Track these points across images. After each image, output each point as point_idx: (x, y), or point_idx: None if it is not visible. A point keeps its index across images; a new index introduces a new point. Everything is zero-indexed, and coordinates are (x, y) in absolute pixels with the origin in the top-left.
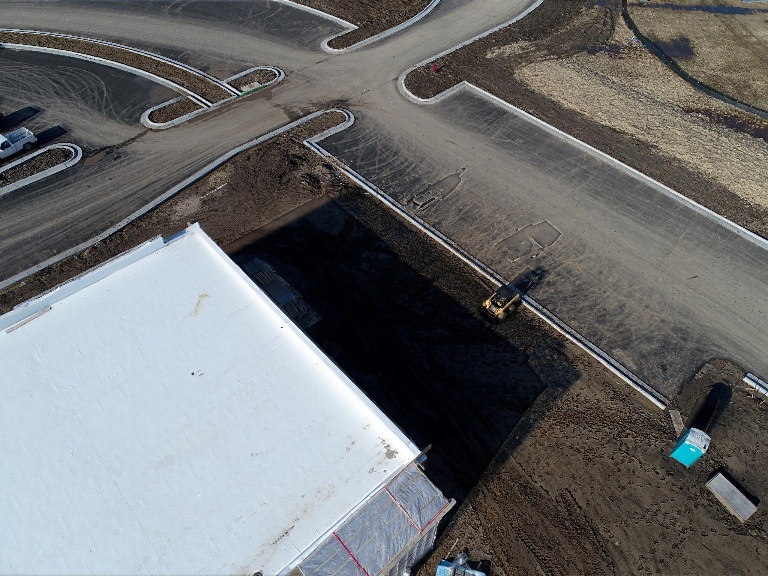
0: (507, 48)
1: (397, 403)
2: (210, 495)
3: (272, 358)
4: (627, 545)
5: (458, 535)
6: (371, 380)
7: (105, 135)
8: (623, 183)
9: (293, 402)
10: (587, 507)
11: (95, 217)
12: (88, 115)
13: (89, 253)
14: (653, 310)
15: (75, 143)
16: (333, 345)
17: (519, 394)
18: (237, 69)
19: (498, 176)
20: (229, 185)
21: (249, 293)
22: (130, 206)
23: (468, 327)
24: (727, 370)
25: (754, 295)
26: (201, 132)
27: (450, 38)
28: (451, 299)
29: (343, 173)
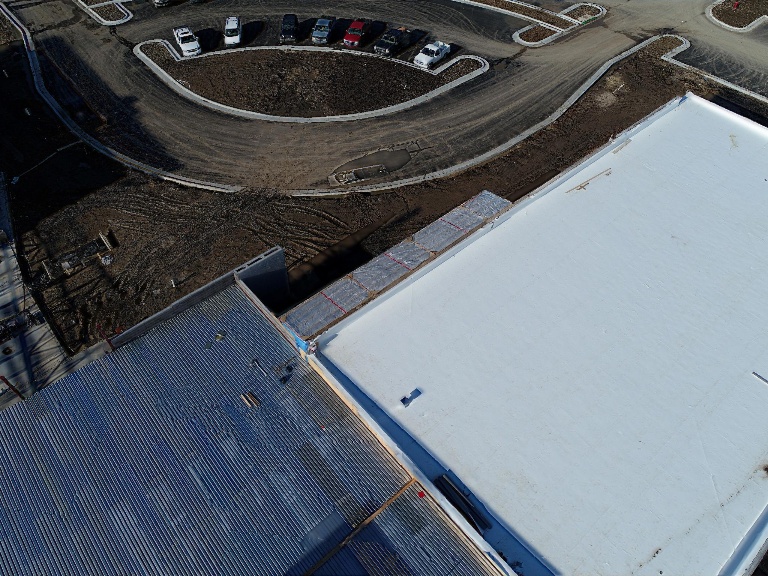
0: None
1: None
2: None
3: None
4: None
5: None
6: None
7: (495, 50)
8: None
9: None
10: None
11: (536, 105)
12: (469, 36)
13: (555, 127)
14: None
15: (476, 55)
16: None
17: None
18: (563, 5)
19: None
20: (627, 85)
21: (764, 135)
22: (557, 98)
23: None
24: None
25: None
26: (570, 49)
27: None
28: None
29: (710, 79)
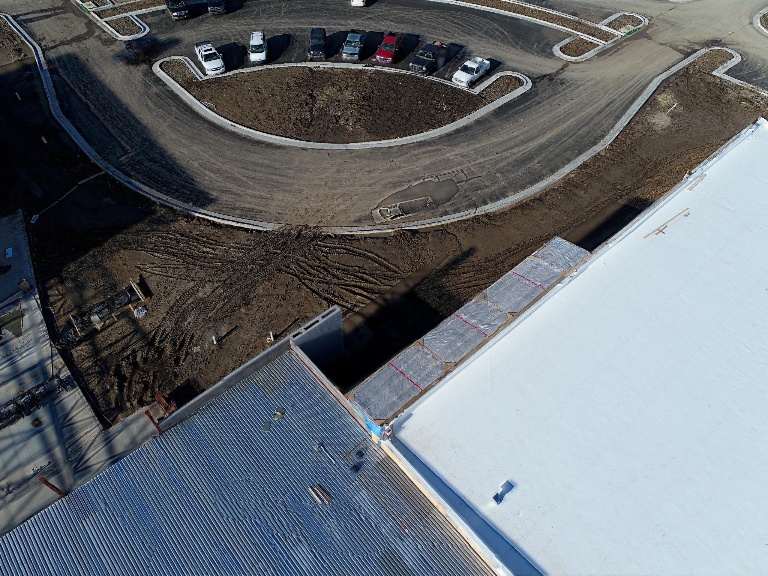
0: None
1: None
2: None
3: None
4: None
5: None
6: None
7: (536, 66)
8: None
9: None
10: None
11: (586, 127)
12: (507, 50)
13: (609, 153)
14: None
15: (517, 71)
16: None
17: None
18: (603, 14)
19: None
20: (680, 104)
21: None
22: (608, 119)
23: None
24: None
25: None
26: (615, 64)
27: None
28: None
29: (767, 97)
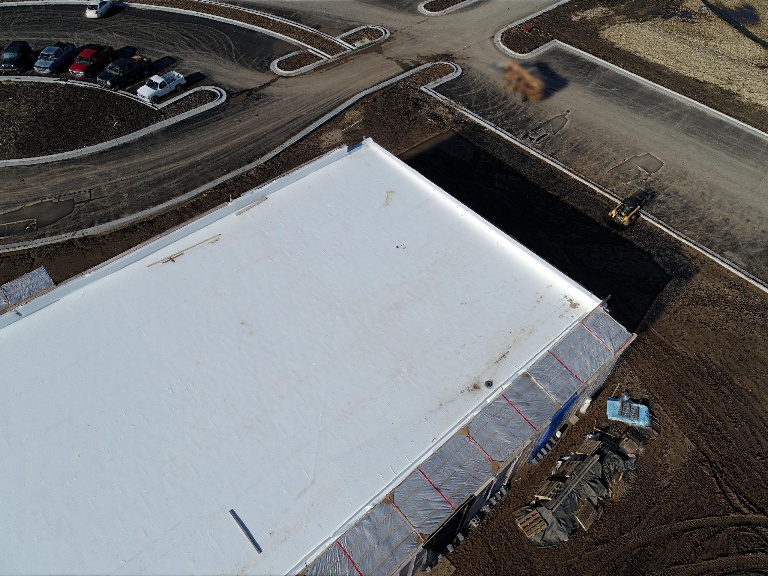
0: (589, 12)
1: None
2: (436, 330)
3: (459, 237)
4: (758, 391)
5: (619, 381)
6: None
7: (242, 80)
8: (713, 124)
9: (485, 268)
10: (721, 364)
11: (252, 145)
12: (223, 64)
13: (256, 172)
14: (754, 223)
15: (218, 86)
16: None
17: (650, 282)
18: (346, 27)
19: (600, 117)
20: (364, 121)
21: (427, 190)
22: (280, 137)
23: (598, 232)
24: None
25: None
26: (327, 79)
27: (535, 4)
28: (578, 211)
29: (462, 113)
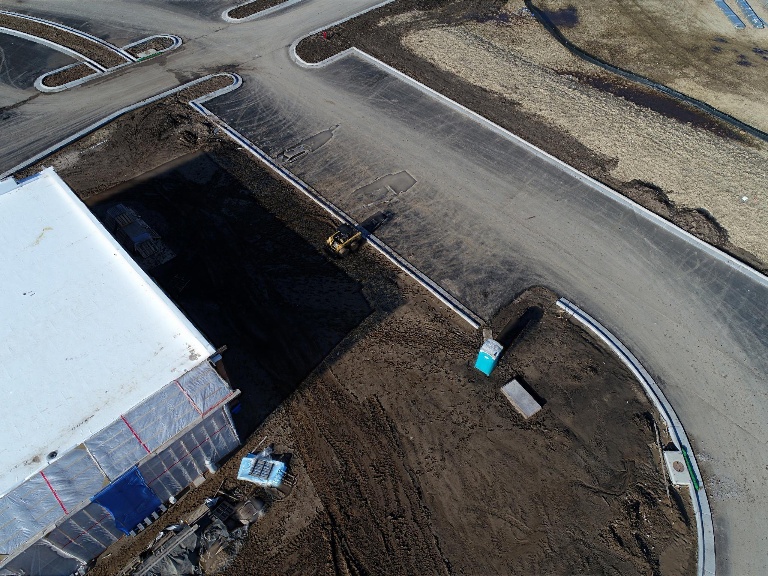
0: (400, 17)
1: (233, 326)
2: (21, 392)
3: (101, 280)
4: (419, 439)
5: (267, 433)
6: (212, 308)
7: None
8: (484, 137)
9: (113, 316)
10: (390, 409)
11: None
12: None
13: None
14: (487, 246)
15: None
16: (182, 278)
17: (347, 317)
18: (136, 37)
19: (368, 132)
20: (109, 141)
21: (90, 226)
22: (11, 161)
23: (311, 262)
24: (544, 296)
25: (582, 232)
26: (92, 95)
27: (348, 8)
28: (301, 238)
29: (222, 130)
